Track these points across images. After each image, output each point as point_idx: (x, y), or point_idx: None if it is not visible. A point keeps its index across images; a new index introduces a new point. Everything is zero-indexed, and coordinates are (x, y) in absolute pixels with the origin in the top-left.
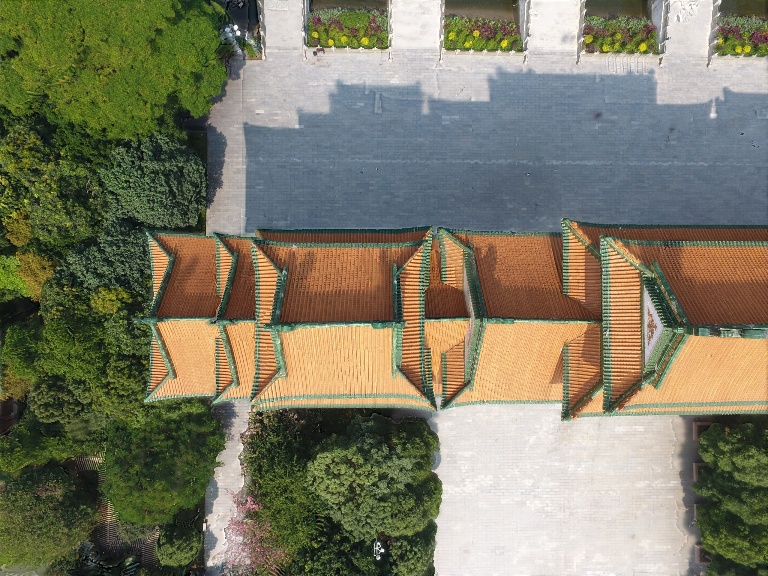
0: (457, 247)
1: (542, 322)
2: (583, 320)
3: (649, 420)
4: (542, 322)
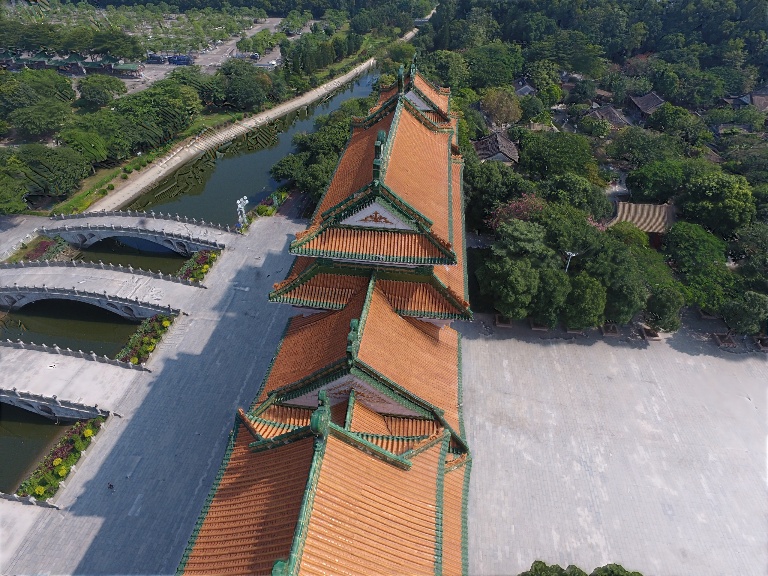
0: (267, 412)
1: (364, 311)
2: (369, 283)
3: (497, 355)
4: (364, 311)
